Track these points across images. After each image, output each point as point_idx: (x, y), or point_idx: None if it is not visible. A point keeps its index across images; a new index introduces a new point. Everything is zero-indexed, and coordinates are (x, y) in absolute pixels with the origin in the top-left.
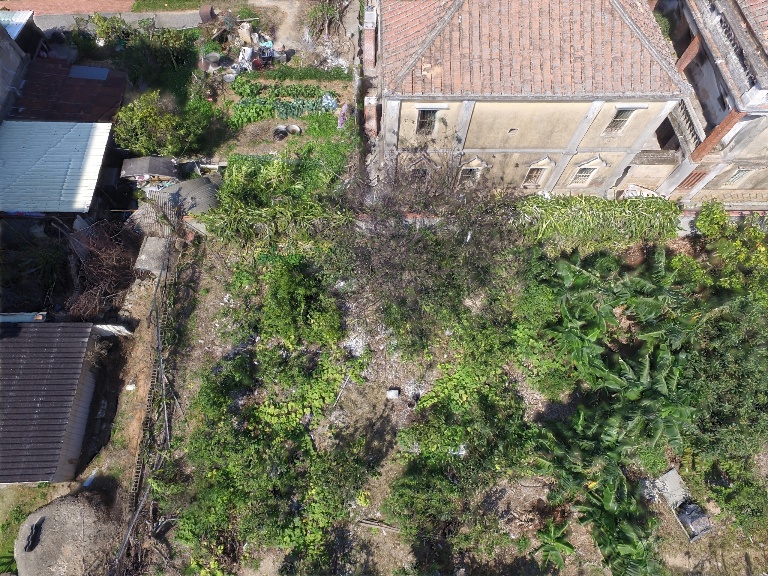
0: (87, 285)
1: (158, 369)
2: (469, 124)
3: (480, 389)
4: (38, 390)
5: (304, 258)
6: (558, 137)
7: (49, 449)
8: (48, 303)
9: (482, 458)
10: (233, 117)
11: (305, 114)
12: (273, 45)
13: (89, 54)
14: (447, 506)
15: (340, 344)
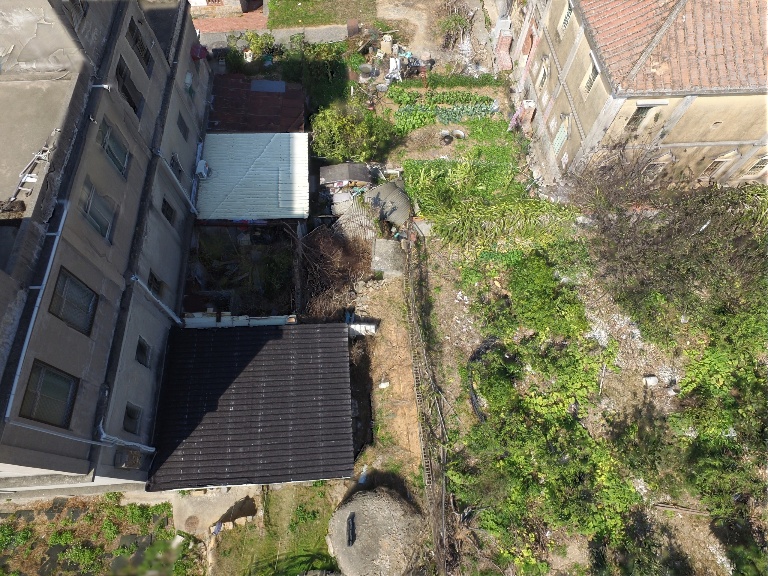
0: (319, 288)
1: (419, 365)
2: (678, 119)
3: (735, 373)
4: (315, 389)
5: (523, 254)
6: (756, 129)
7: (342, 446)
8: (294, 306)
9: (767, 438)
10: (399, 124)
11: (464, 119)
12: (412, 55)
13: (241, 70)
14: (759, 484)
15: (584, 335)
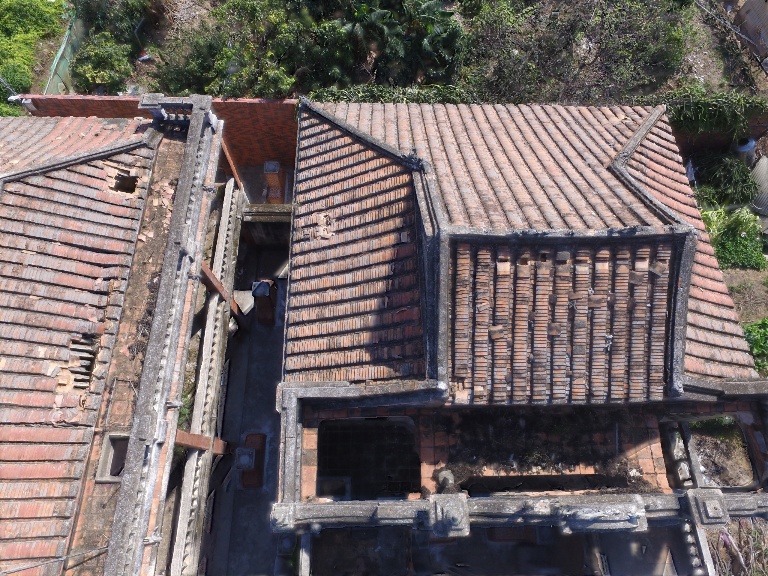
0: None
1: None
2: None
3: None
4: None
5: None
6: None
7: None
8: None
9: None
10: None
11: None
12: None
13: None
14: None
15: None
